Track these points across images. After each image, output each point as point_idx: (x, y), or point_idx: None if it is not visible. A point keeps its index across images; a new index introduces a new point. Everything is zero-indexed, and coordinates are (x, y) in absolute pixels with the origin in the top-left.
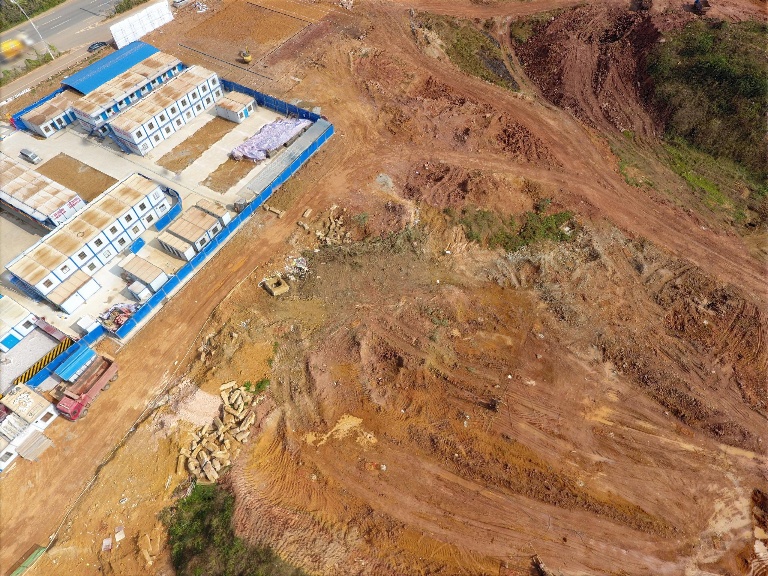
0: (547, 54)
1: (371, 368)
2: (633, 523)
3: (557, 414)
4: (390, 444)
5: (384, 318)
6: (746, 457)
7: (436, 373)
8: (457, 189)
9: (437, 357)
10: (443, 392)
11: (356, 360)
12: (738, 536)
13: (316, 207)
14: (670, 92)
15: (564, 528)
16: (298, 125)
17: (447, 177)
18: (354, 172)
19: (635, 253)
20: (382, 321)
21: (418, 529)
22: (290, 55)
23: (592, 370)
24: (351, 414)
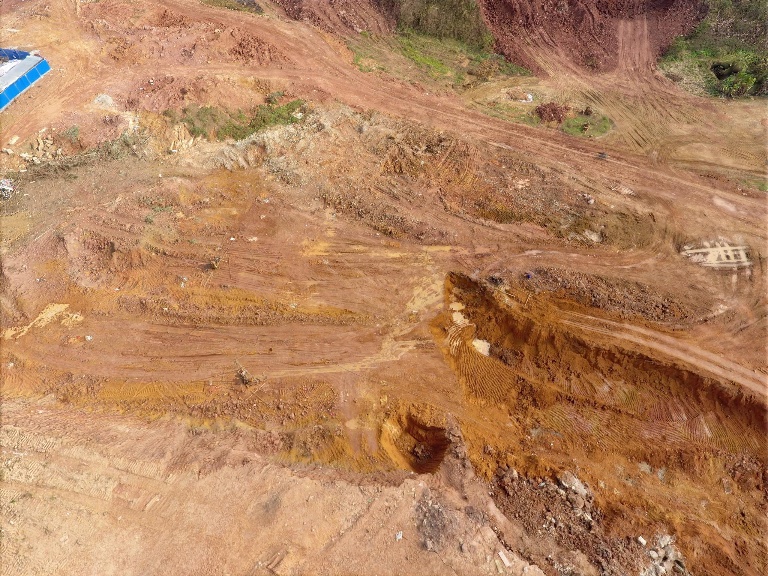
0: None
1: (83, 261)
2: (336, 321)
3: (276, 258)
4: (97, 317)
5: (97, 214)
6: (444, 251)
7: (155, 251)
8: (177, 93)
9: (154, 236)
10: (162, 265)
11: (63, 255)
12: (431, 309)
13: (25, 134)
14: None
15: (270, 341)
16: (4, 65)
17: (169, 86)
18: (71, 98)
19: (360, 121)
20: (94, 217)
21: (121, 378)
22: (8, 10)
23: (313, 217)
24: (56, 302)
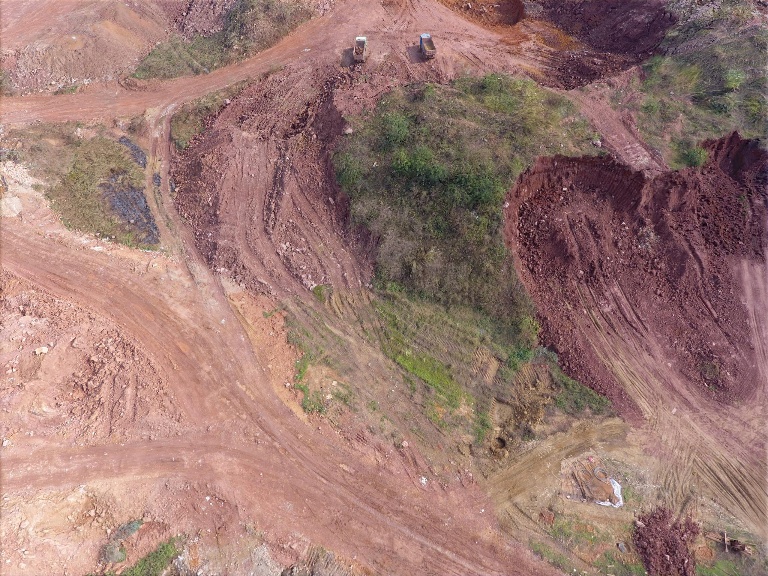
0: (200, 172)
1: None
2: None
3: None
4: None
5: None
6: None
7: None
8: None
9: None
10: None
11: None
12: None
13: None
14: (370, 212)
15: None
16: None
17: None
18: None
19: None
20: None
21: None
22: None
23: None
24: None
